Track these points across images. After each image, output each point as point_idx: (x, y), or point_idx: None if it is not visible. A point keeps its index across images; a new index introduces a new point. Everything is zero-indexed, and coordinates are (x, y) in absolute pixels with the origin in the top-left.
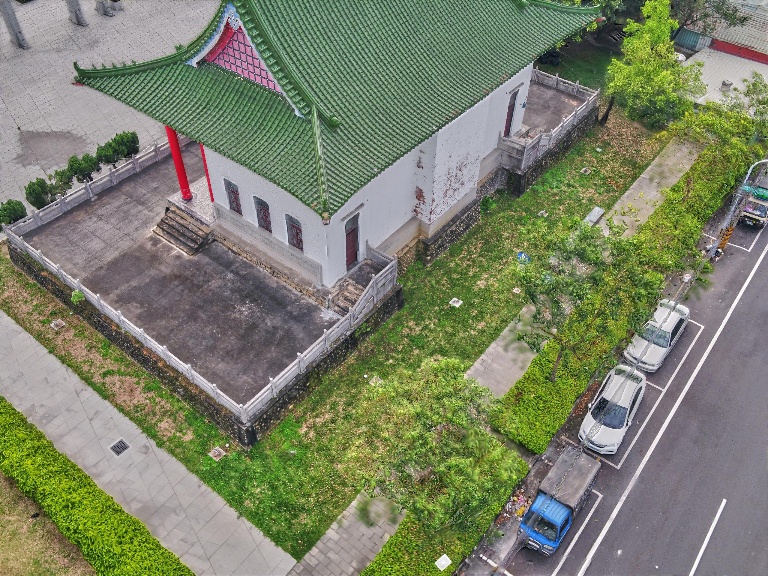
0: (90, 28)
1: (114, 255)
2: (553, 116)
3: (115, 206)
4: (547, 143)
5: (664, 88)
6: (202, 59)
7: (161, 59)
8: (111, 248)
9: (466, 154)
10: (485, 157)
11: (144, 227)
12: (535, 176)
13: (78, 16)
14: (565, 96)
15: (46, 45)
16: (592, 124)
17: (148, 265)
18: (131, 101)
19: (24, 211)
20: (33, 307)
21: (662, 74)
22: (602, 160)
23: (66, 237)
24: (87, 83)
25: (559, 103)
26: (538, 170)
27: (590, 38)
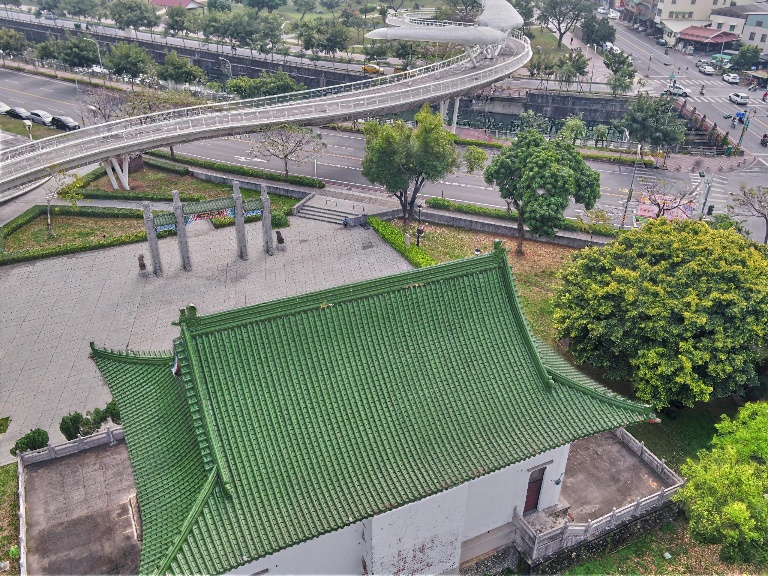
0: (247, 263)
1: (81, 514)
2: (616, 495)
3: (122, 458)
4: (582, 533)
5: (738, 523)
6: (178, 372)
7: (155, 358)
8: (85, 504)
9: (431, 537)
10: (491, 530)
11: (126, 491)
12: (558, 568)
13: (242, 251)
14: (647, 471)
15: (204, 271)
16: (673, 516)
17: (98, 537)
18: (114, 390)
19: (45, 442)
20: (1, 538)
21: (733, 507)
22: (663, 572)
23: (62, 478)
24: (95, 361)
25: (634, 478)
26: (564, 562)
27: (734, 394)
